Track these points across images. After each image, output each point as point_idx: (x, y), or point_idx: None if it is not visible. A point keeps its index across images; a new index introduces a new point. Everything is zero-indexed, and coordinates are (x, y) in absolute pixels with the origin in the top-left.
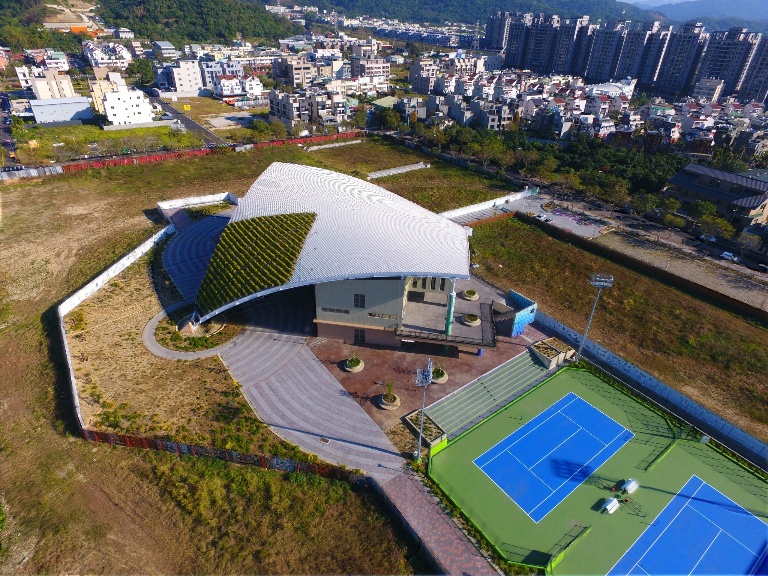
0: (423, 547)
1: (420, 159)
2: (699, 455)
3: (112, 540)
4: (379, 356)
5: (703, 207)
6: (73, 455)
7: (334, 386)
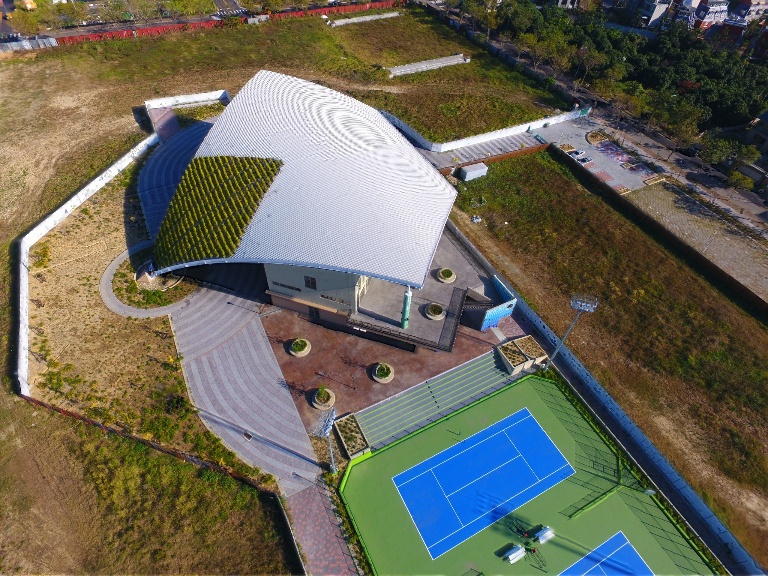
0: None
1: (461, 48)
2: (637, 508)
3: (34, 515)
4: (330, 338)
5: None
6: (15, 416)
7: (273, 371)
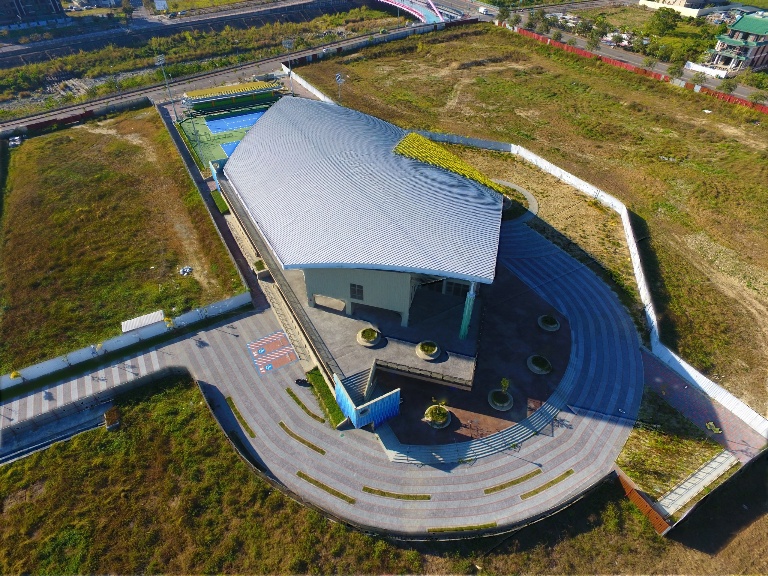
0: None
1: None
2: None
3: None
4: None
5: None
6: None
7: None
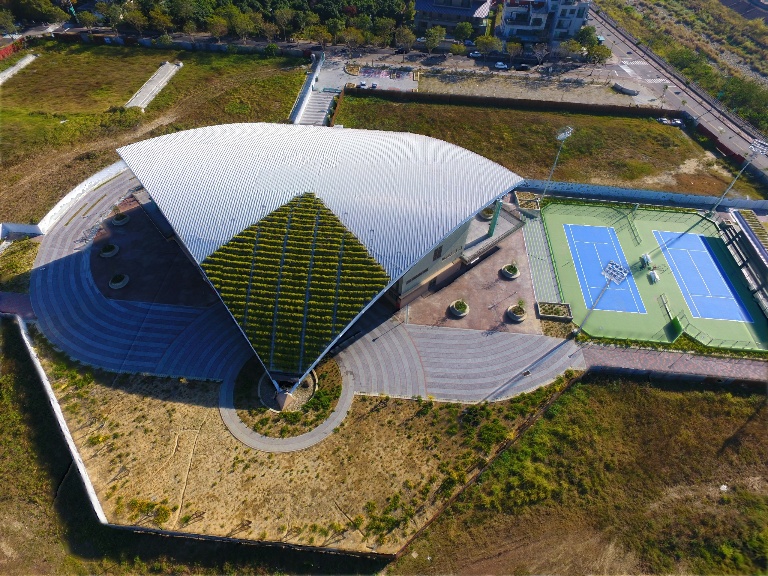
0: (653, 374)
1: (155, 58)
2: (642, 218)
3: (537, 569)
4: (460, 288)
5: (467, 28)
6: None
7: (473, 335)
